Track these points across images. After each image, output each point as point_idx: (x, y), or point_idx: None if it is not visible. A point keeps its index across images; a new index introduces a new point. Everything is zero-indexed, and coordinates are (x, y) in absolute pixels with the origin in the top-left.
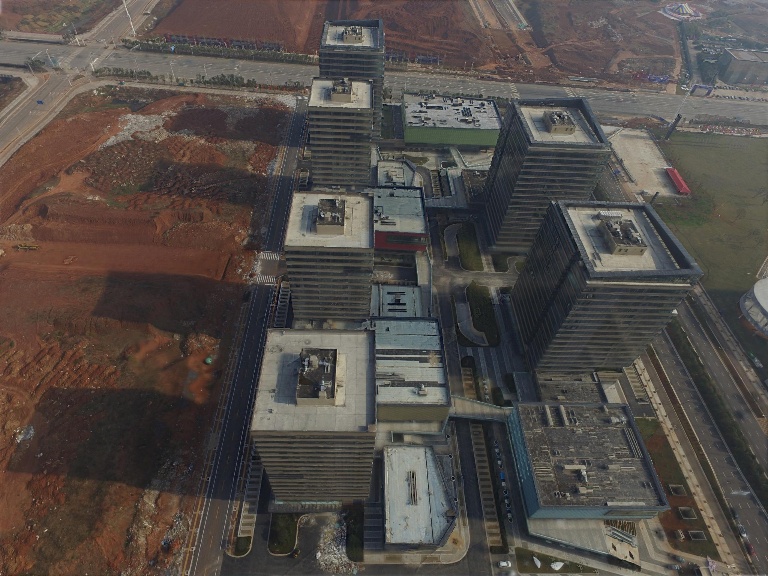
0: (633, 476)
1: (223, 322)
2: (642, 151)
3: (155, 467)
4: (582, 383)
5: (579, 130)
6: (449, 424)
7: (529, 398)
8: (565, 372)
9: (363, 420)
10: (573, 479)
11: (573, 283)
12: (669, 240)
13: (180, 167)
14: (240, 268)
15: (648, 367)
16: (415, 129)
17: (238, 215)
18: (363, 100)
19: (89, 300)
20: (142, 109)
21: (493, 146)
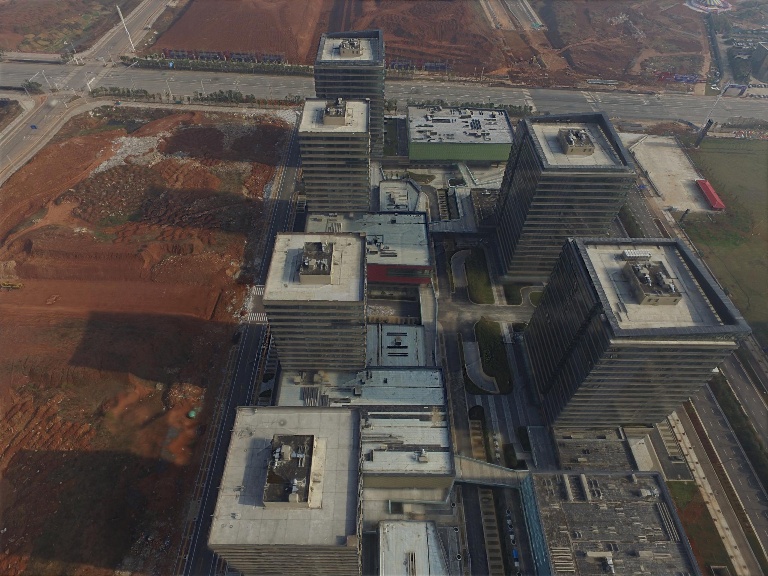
0: (669, 565)
1: (210, 368)
2: (669, 161)
3: (128, 542)
4: (606, 441)
5: (599, 150)
6: (455, 489)
7: (545, 458)
8: (586, 428)
9: (342, 528)
10: (597, 569)
11: (594, 339)
12: (708, 286)
13: (172, 193)
14: (231, 305)
15: (682, 417)
16: (420, 145)
17: (230, 245)
18: (358, 122)
19: (67, 347)
20: (137, 130)
21: (505, 160)
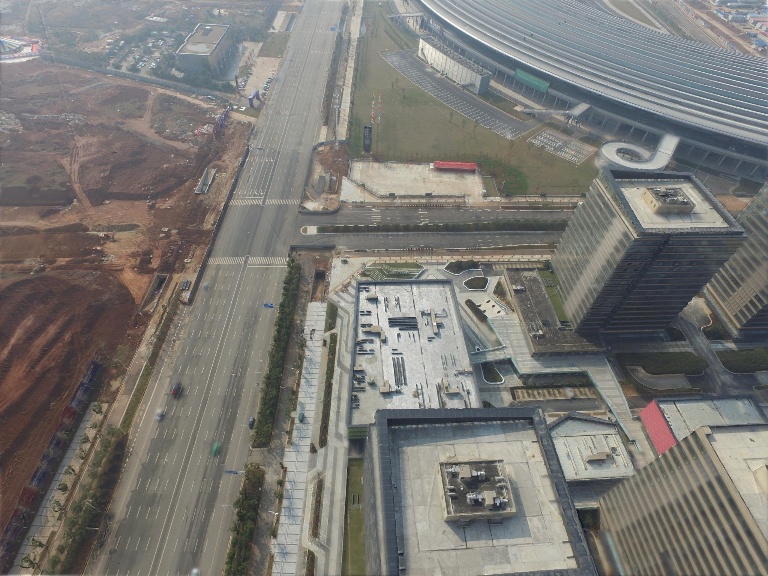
0: None
1: None
2: (397, 175)
3: None
4: None
5: None
6: None
7: None
8: None
9: None
10: None
11: None
12: None
13: None
14: None
15: None
16: None
17: None
18: None
19: None
20: None
21: None
